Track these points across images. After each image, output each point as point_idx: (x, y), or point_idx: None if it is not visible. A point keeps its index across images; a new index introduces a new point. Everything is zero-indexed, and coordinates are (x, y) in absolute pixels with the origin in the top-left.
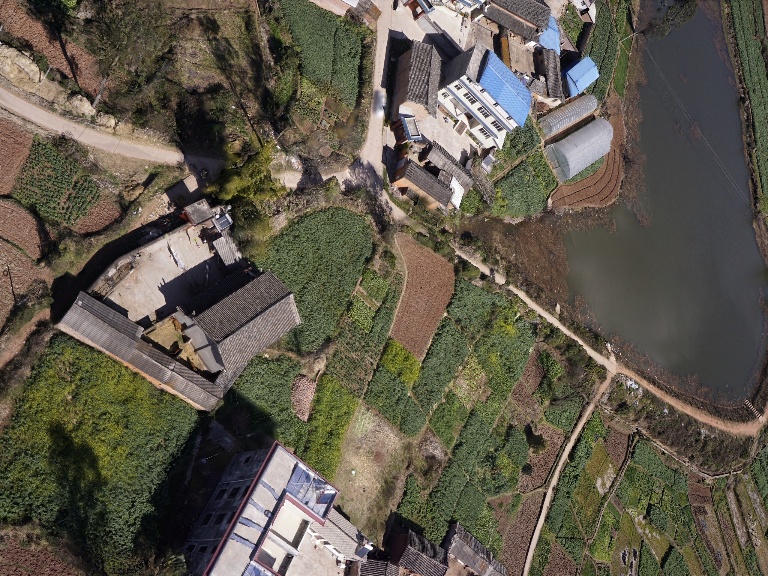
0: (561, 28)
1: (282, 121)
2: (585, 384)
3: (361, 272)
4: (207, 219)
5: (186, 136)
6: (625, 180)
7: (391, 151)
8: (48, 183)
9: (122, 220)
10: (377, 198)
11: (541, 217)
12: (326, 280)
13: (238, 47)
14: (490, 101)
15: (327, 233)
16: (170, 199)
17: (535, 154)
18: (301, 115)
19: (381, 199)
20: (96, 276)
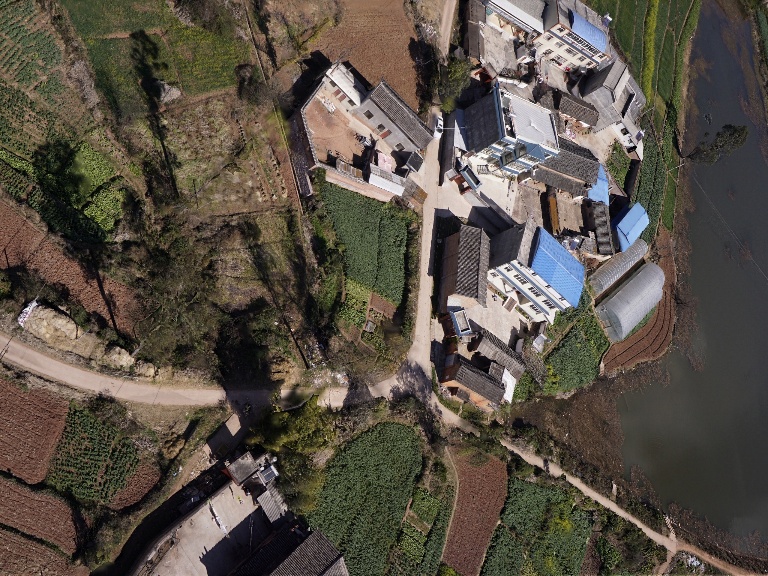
0: (609, 174)
1: (327, 330)
2: (644, 567)
3: (411, 493)
4: (251, 475)
5: (228, 370)
6: (677, 323)
7: (439, 345)
8: (84, 458)
9: (162, 486)
10: (426, 403)
11: (593, 384)
12: (375, 510)
13: (280, 252)
14: (542, 283)
15: (375, 455)
16: (212, 450)
17: (586, 315)
18: (346, 321)
19: (430, 403)
20: (134, 558)
